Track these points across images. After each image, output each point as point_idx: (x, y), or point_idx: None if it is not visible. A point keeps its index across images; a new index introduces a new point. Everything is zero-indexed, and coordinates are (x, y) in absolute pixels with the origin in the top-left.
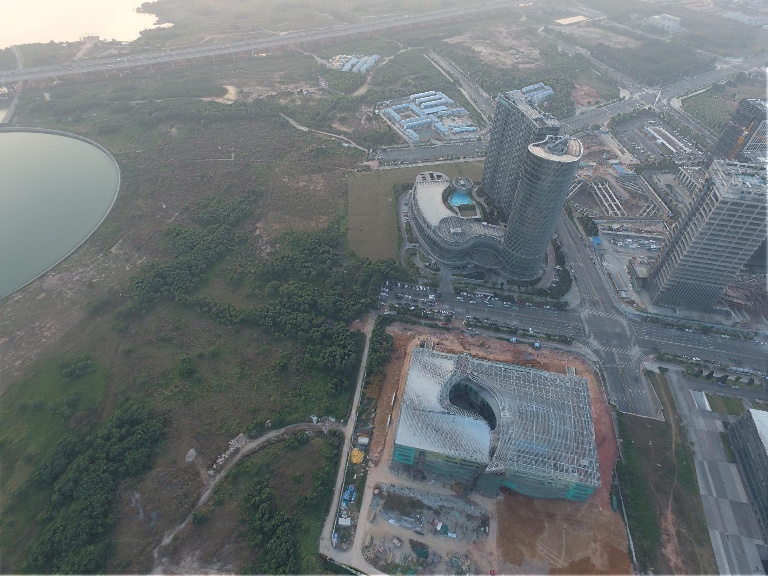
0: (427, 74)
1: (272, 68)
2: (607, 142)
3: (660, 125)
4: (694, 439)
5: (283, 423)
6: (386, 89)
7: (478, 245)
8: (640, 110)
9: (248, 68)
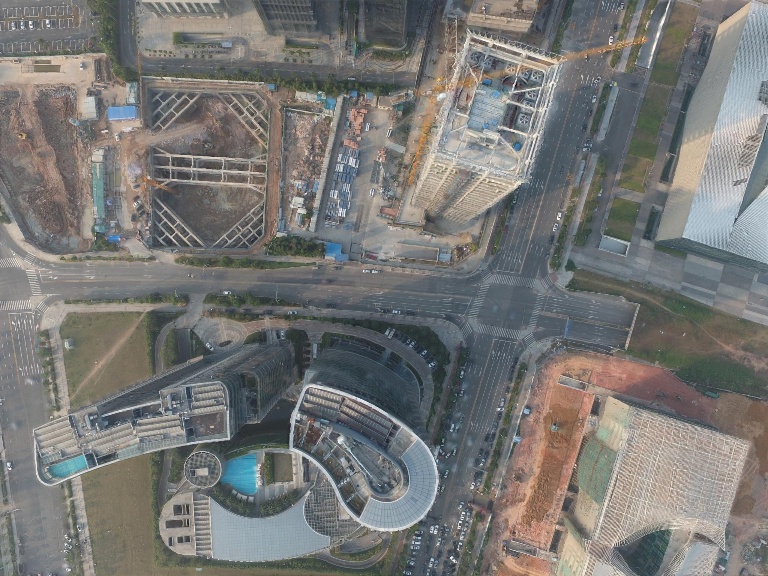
0: None
1: None
2: (4, 82)
3: None
4: (659, 281)
5: None
6: None
7: None
8: None
9: None
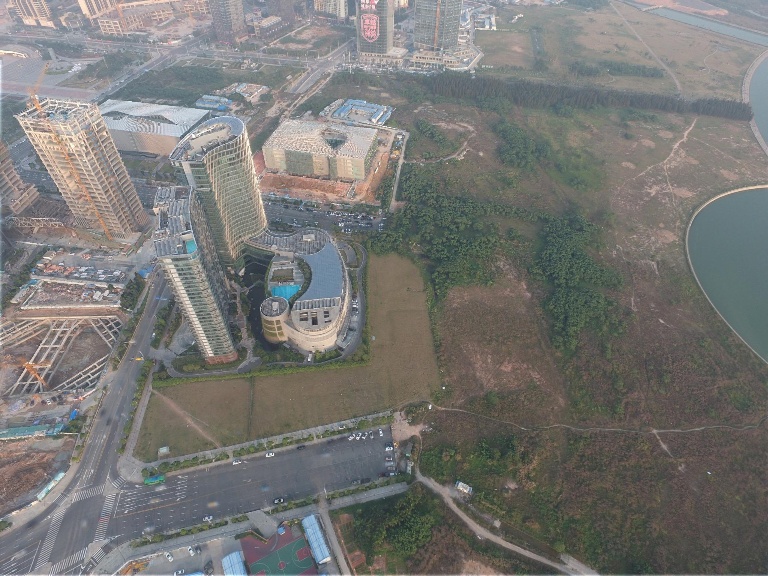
0: None
1: None
2: None
3: None
4: None
5: None
6: None
7: None
8: None
9: None
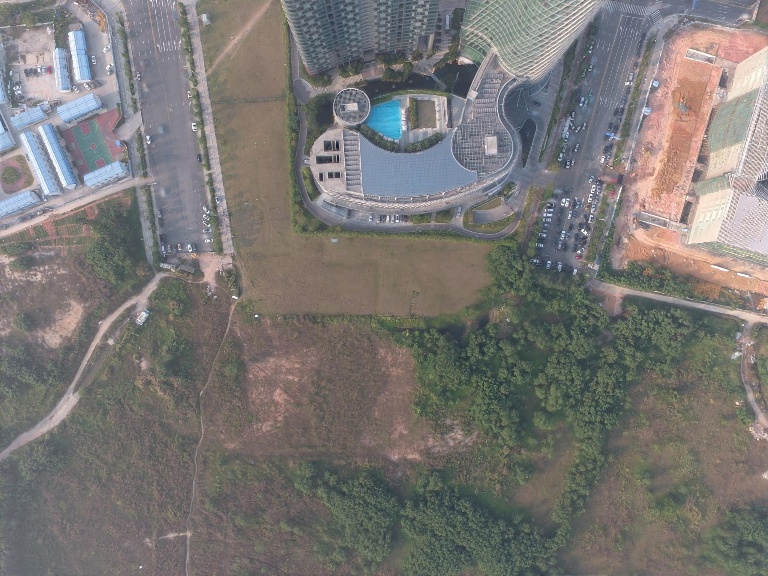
0: None
1: None
2: None
3: None
4: None
5: (743, 387)
6: None
7: None
8: None
9: None
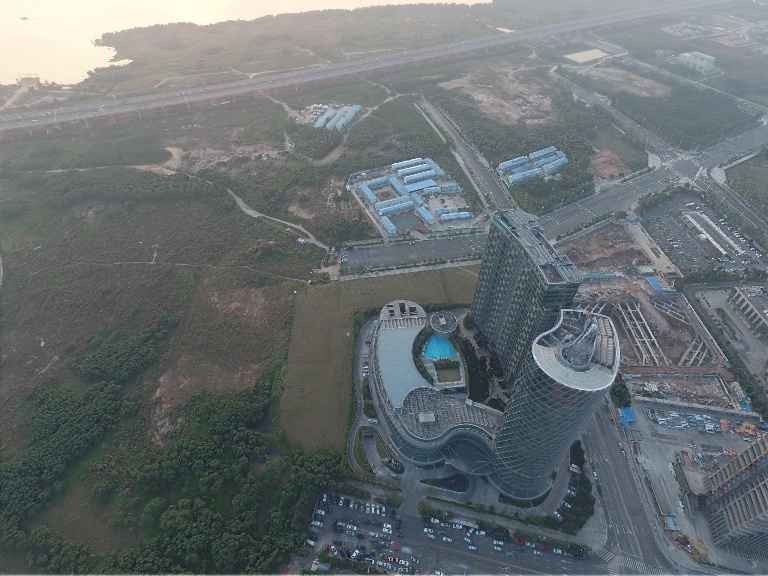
0: (415, 133)
1: (231, 122)
2: (636, 237)
3: (701, 209)
4: None
5: None
6: (364, 153)
7: (459, 436)
8: (675, 188)
9: (203, 122)
